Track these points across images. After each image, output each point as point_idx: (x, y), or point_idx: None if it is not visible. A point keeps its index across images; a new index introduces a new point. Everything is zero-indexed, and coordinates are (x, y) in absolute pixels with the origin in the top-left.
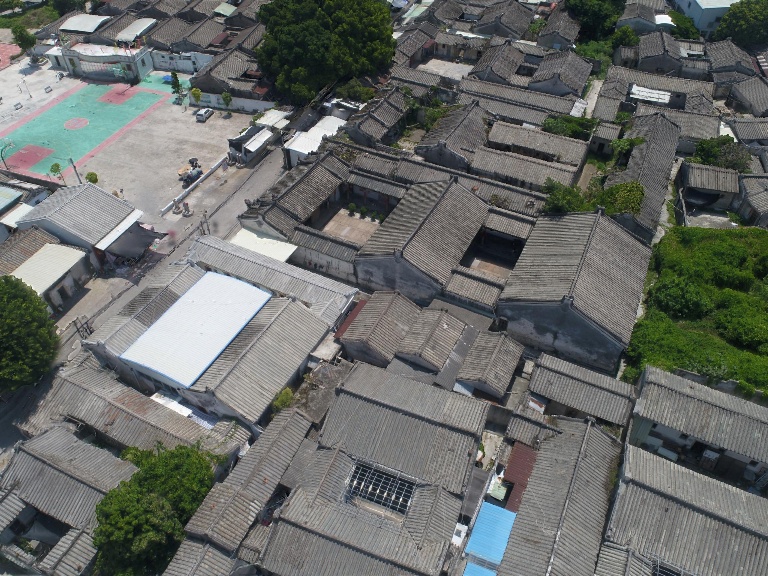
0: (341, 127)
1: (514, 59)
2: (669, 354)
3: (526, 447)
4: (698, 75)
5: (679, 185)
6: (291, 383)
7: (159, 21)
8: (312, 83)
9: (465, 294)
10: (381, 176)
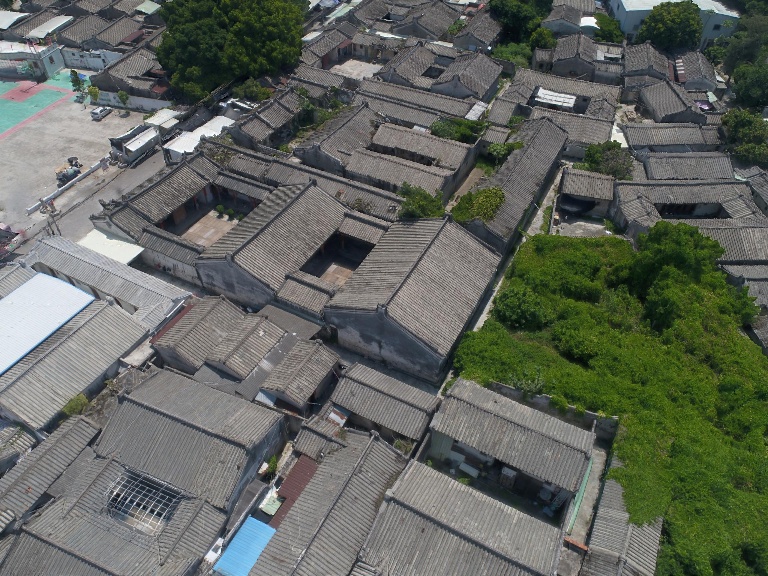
0: (224, 127)
1: (424, 60)
2: (492, 366)
3: (310, 460)
4: (611, 79)
5: (559, 191)
6: (96, 389)
7: (77, 18)
8: (207, 82)
9: (295, 300)
10: (253, 178)
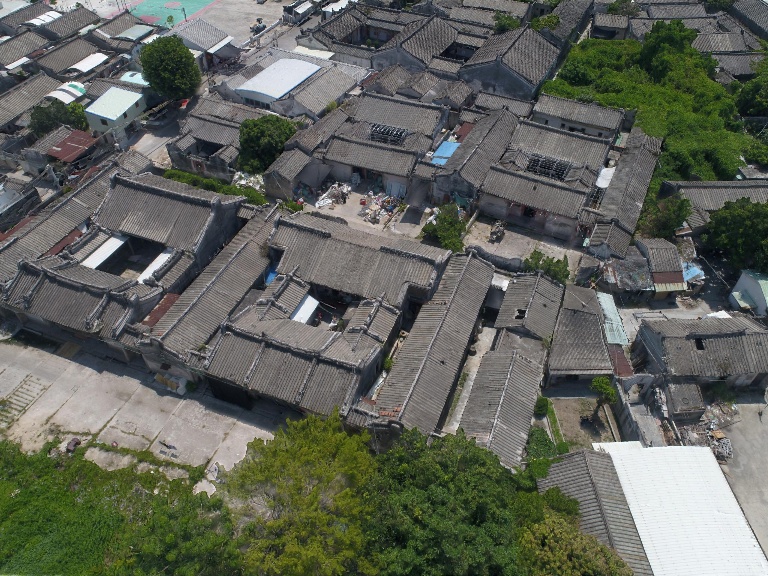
0: None
1: None
2: (562, 95)
3: (470, 124)
4: None
5: None
6: None
7: None
8: None
9: (440, 68)
10: None
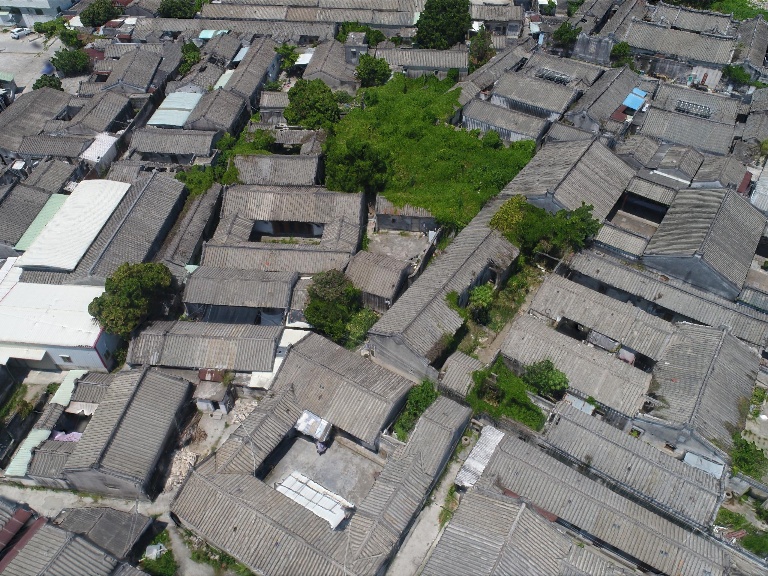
0: None
1: None
2: None
3: None
4: None
5: None
6: None
7: None
8: None
9: None
10: None
